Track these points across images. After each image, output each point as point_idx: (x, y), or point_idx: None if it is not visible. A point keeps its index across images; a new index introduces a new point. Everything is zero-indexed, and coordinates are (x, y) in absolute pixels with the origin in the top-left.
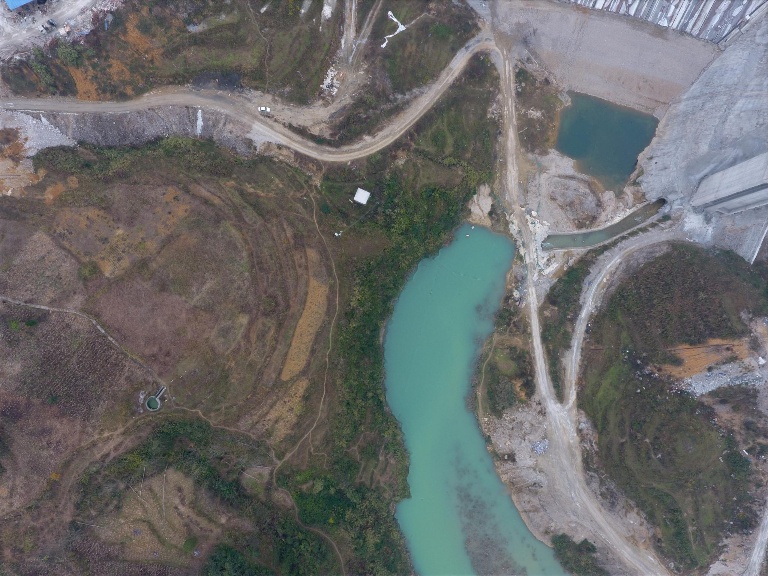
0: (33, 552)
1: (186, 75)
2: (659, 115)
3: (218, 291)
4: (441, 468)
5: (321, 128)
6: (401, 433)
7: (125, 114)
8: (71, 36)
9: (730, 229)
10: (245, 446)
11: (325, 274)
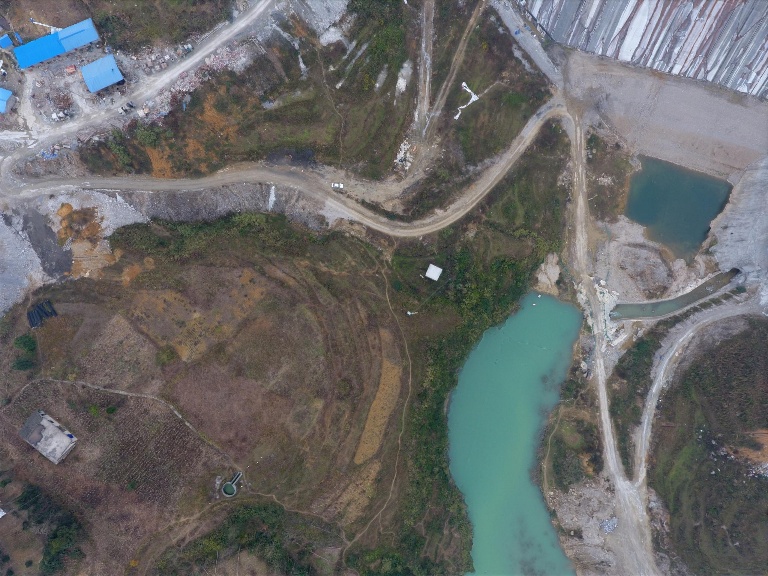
0: None
1: (260, 152)
2: (733, 181)
3: (294, 376)
4: (504, 541)
5: (394, 204)
6: (465, 505)
7: (199, 191)
8: (150, 117)
9: None
10: (317, 529)
11: (398, 355)
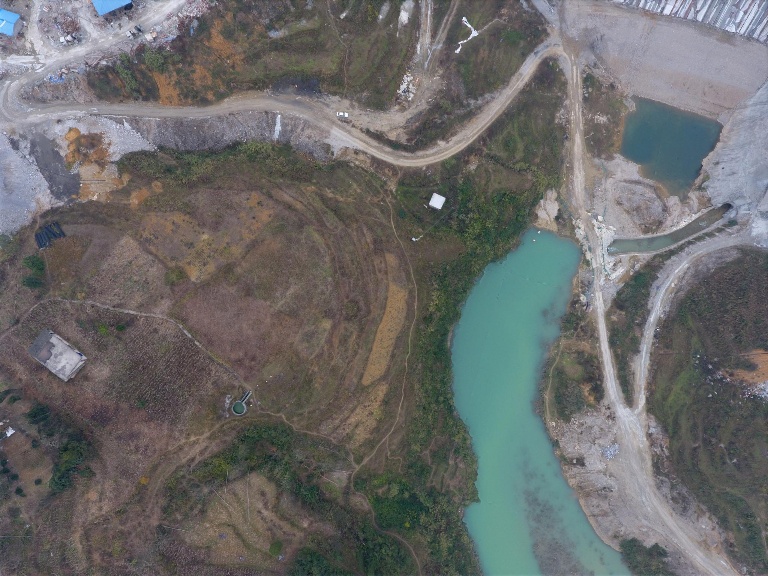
0: (121, 556)
1: (266, 80)
2: (723, 120)
3: (302, 296)
4: (509, 472)
5: (398, 133)
6: (469, 437)
7: (206, 119)
8: (157, 42)
9: None
10: (326, 450)
11: (404, 279)
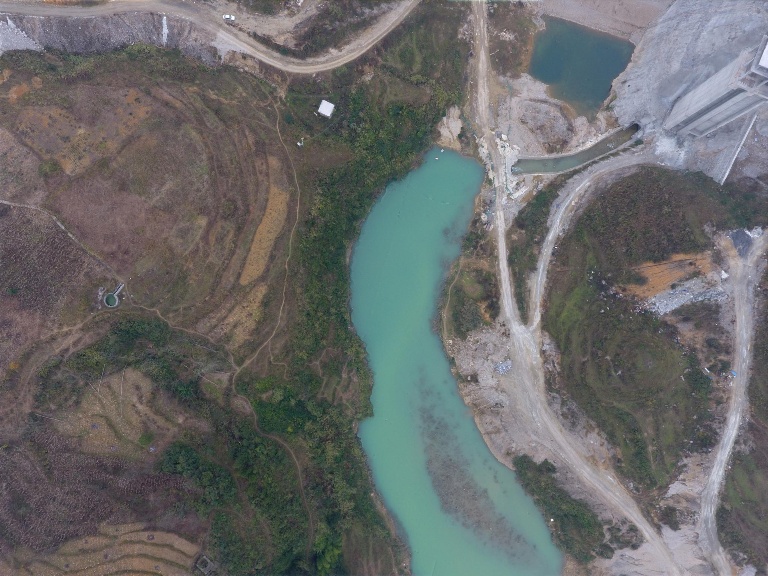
0: None
1: None
2: (635, 40)
3: (177, 192)
4: (405, 389)
5: (286, 38)
6: (365, 353)
7: (90, 19)
8: None
9: (702, 153)
10: (203, 349)
11: (286, 181)
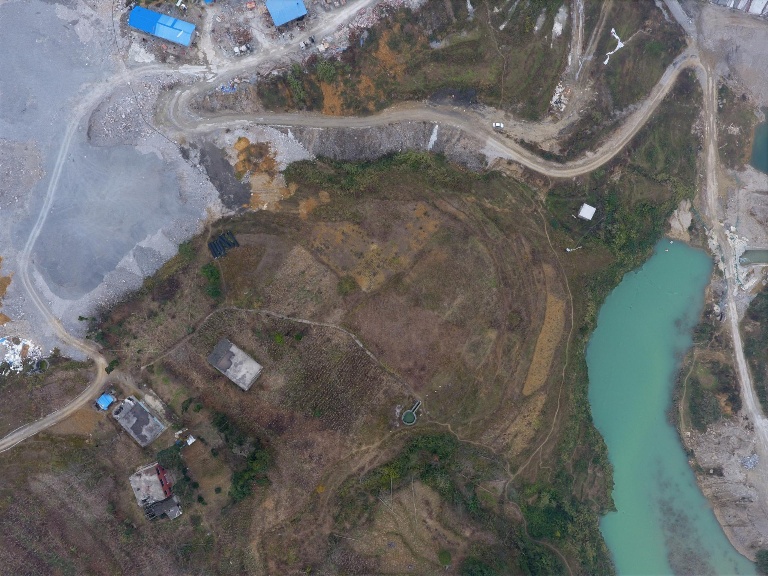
0: (295, 564)
1: (426, 91)
2: None
3: (469, 306)
4: (643, 481)
5: (551, 144)
6: None
7: (366, 129)
8: (328, 52)
9: None
10: (487, 460)
11: (562, 289)
